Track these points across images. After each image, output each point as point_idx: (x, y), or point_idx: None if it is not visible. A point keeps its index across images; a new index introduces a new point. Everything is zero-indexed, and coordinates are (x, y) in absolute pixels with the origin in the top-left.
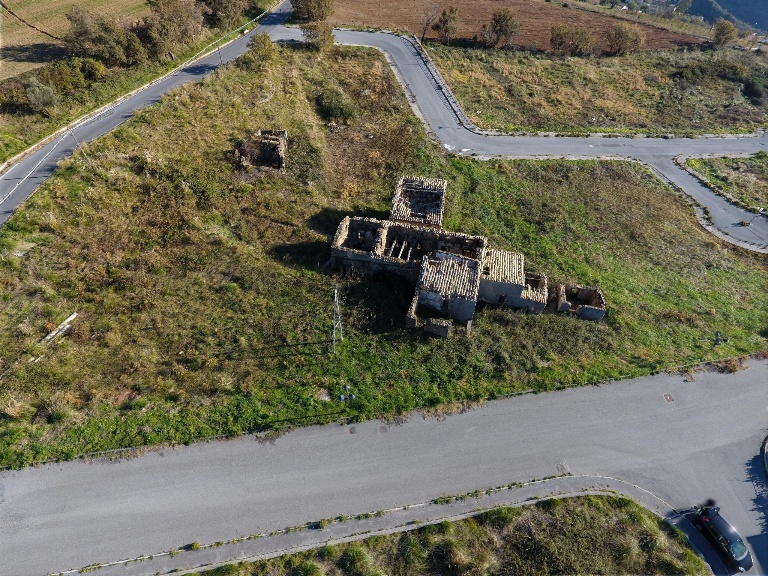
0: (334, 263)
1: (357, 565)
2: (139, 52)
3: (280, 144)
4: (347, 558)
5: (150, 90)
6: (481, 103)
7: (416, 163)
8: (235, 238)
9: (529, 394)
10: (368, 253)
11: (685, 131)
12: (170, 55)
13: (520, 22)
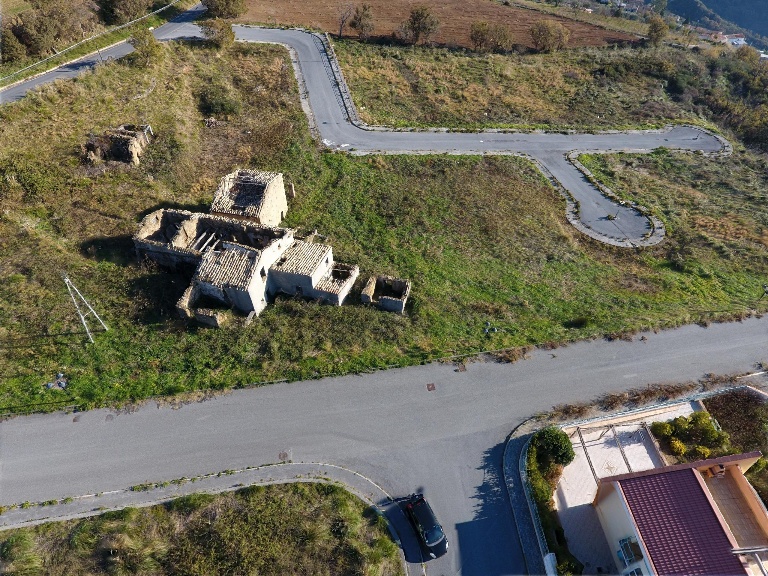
0: (139, 255)
1: (13, 550)
2: (15, 48)
3: (132, 138)
4: (6, 544)
5: (22, 86)
6: (380, 99)
7: (284, 158)
8: (53, 231)
9: (281, 383)
10: (165, 245)
11: (589, 127)
12: (53, 51)
13: (437, 19)
